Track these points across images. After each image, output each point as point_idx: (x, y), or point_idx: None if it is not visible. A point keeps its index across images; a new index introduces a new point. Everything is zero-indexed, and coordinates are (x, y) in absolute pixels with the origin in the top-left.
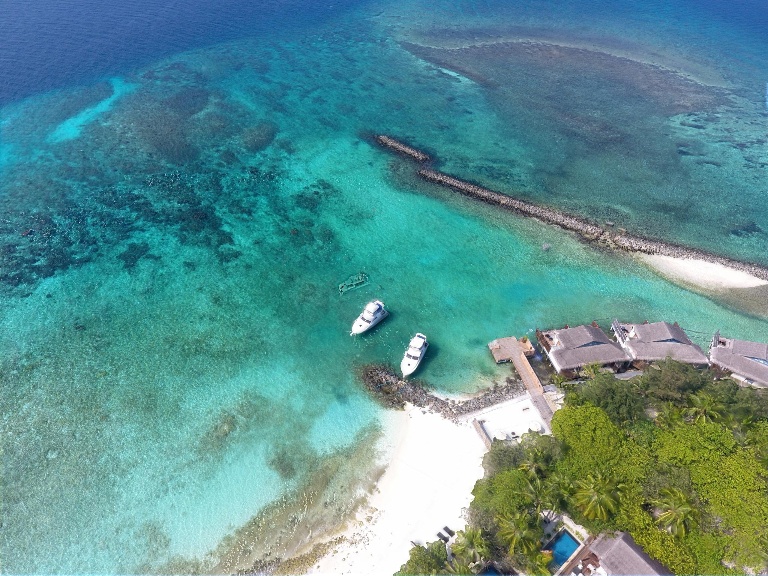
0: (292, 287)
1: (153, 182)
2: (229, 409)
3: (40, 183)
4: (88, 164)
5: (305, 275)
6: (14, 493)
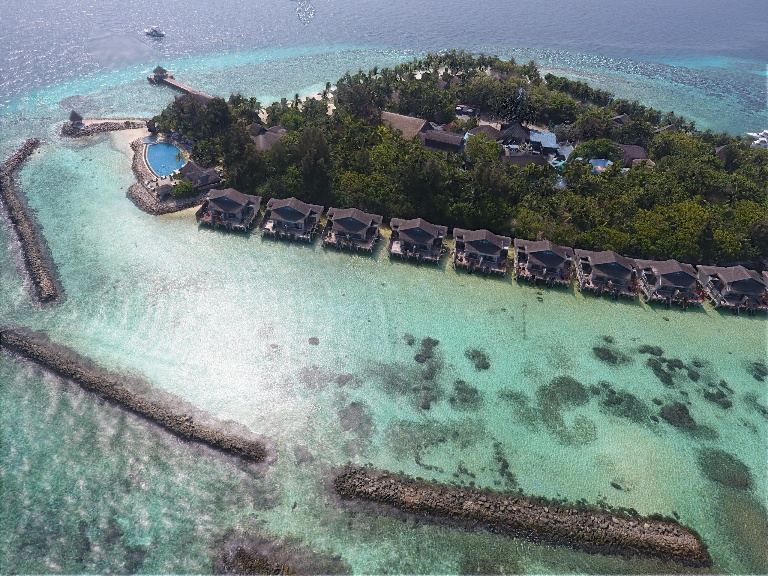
0: (752, 125)
1: (764, 93)
2: (678, 115)
3: (722, 74)
4: (750, 80)
5: (764, 127)
6: (617, 91)
